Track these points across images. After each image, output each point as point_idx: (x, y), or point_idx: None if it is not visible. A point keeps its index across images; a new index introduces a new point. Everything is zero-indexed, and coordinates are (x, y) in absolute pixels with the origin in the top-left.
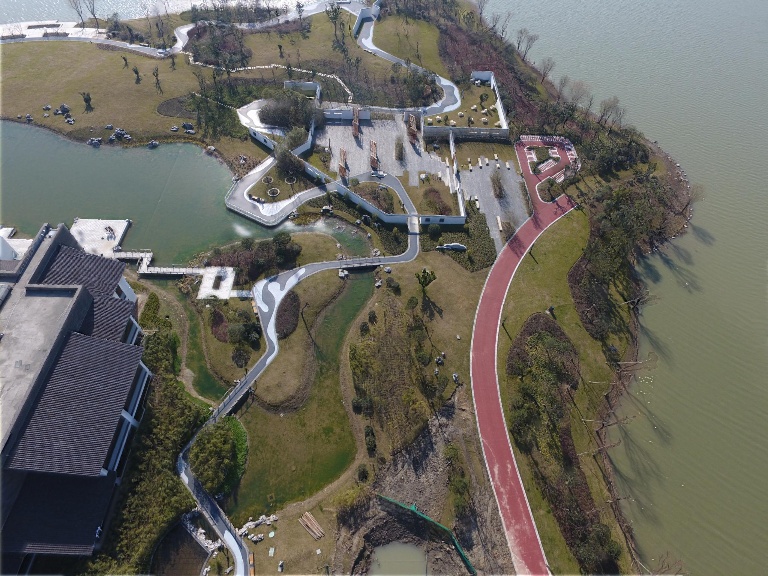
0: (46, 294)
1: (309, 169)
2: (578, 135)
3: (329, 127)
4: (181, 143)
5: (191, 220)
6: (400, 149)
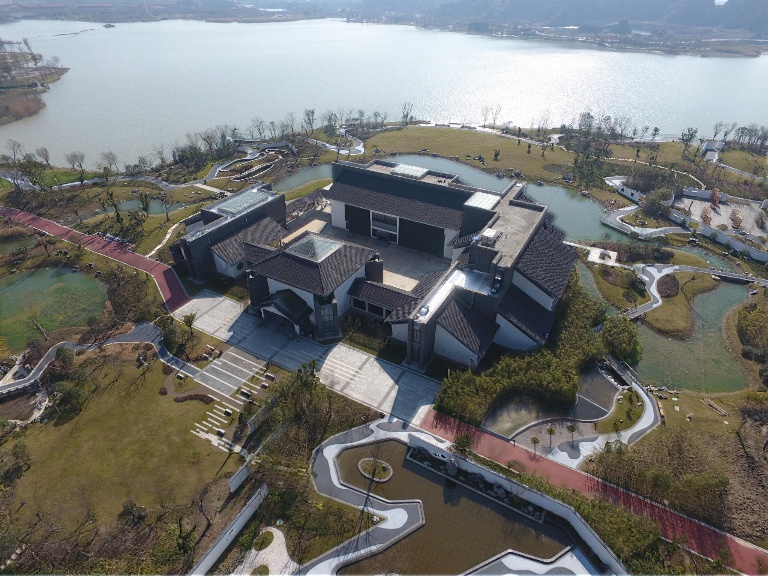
0: (522, 207)
1: (674, 215)
2: None
3: (686, 199)
4: (561, 187)
5: (574, 224)
6: (762, 221)
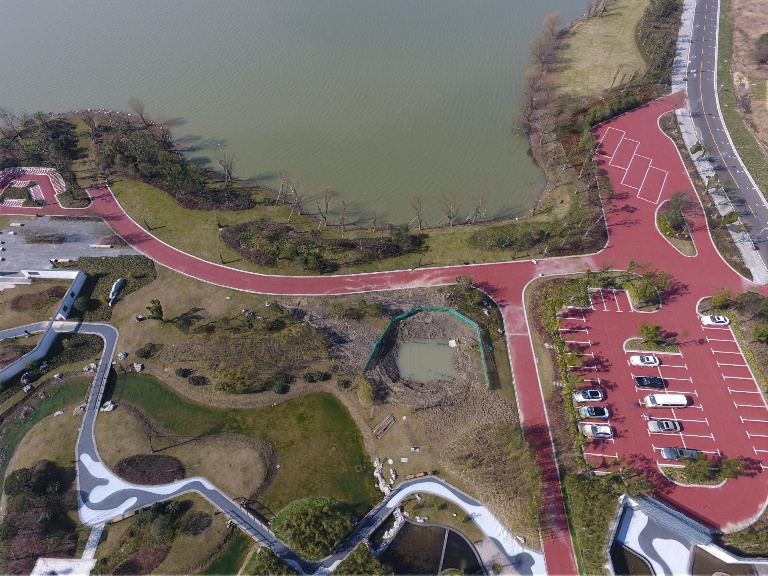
0: None
1: None
2: (6, 159)
3: None
4: None
5: None
6: None
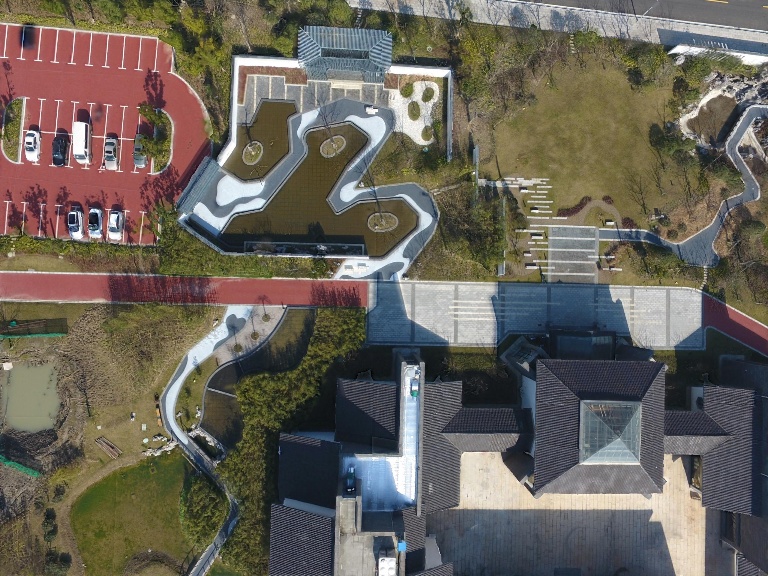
0: None
1: None
2: None
3: None
4: None
5: None
6: None
